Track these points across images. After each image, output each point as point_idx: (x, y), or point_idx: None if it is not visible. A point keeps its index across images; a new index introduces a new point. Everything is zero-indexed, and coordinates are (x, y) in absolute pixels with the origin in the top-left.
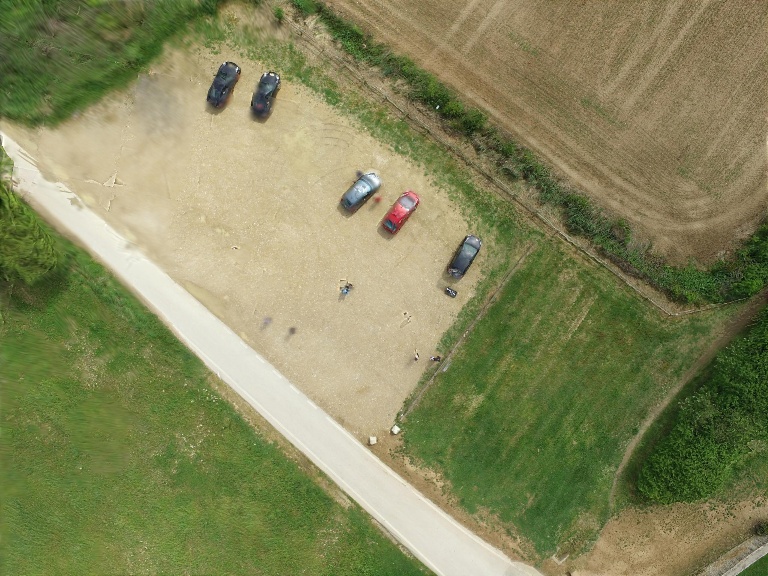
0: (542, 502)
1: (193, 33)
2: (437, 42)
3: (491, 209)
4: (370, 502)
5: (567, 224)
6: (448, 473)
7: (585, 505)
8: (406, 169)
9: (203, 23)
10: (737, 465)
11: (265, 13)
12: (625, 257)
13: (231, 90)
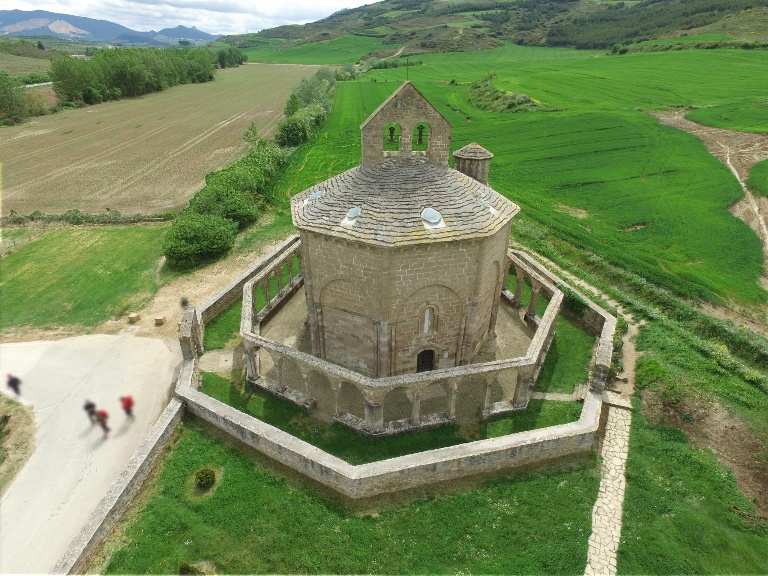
0: (83, 301)
1: None
2: None
3: (5, 232)
4: None
5: (71, 221)
6: None
7: (133, 291)
8: None
9: None
10: (247, 238)
11: None
12: (120, 218)
13: None
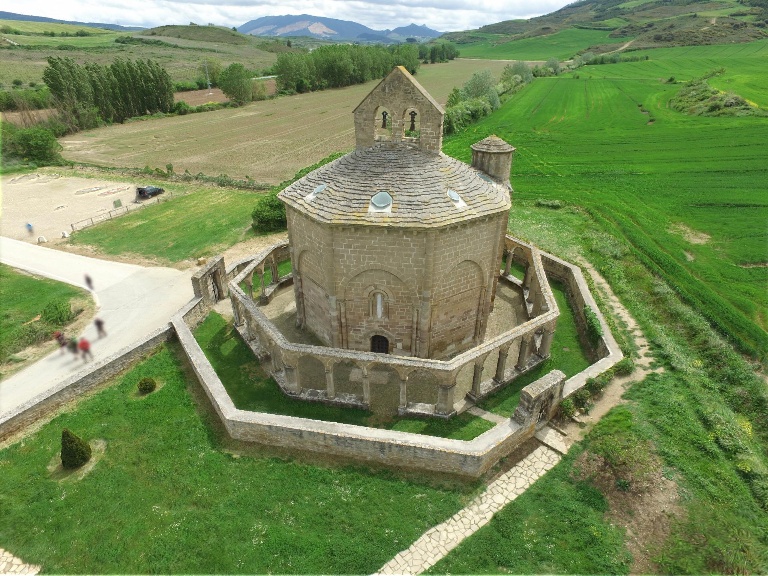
0: (181, 243)
1: (18, 172)
2: (158, 166)
3: None
4: (19, 262)
5: (219, 183)
6: (104, 245)
7: None
8: (126, 184)
9: (26, 170)
10: None
11: (65, 167)
12: None
13: (29, 179)
